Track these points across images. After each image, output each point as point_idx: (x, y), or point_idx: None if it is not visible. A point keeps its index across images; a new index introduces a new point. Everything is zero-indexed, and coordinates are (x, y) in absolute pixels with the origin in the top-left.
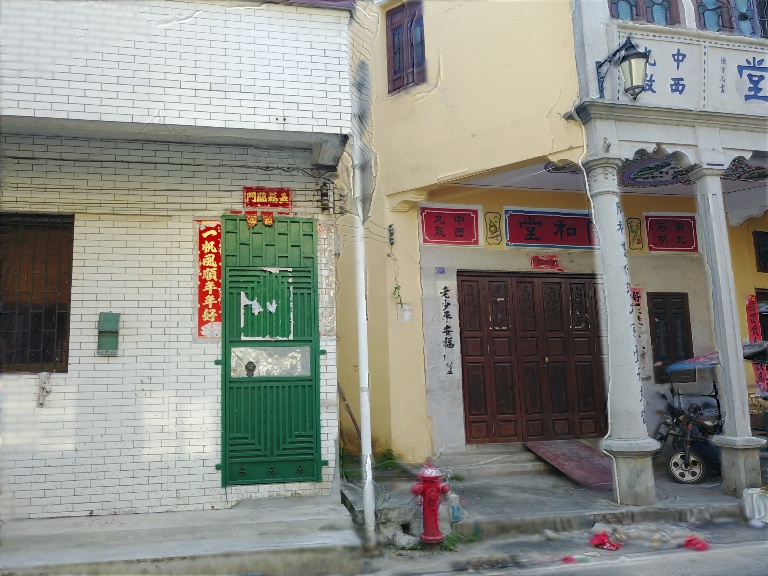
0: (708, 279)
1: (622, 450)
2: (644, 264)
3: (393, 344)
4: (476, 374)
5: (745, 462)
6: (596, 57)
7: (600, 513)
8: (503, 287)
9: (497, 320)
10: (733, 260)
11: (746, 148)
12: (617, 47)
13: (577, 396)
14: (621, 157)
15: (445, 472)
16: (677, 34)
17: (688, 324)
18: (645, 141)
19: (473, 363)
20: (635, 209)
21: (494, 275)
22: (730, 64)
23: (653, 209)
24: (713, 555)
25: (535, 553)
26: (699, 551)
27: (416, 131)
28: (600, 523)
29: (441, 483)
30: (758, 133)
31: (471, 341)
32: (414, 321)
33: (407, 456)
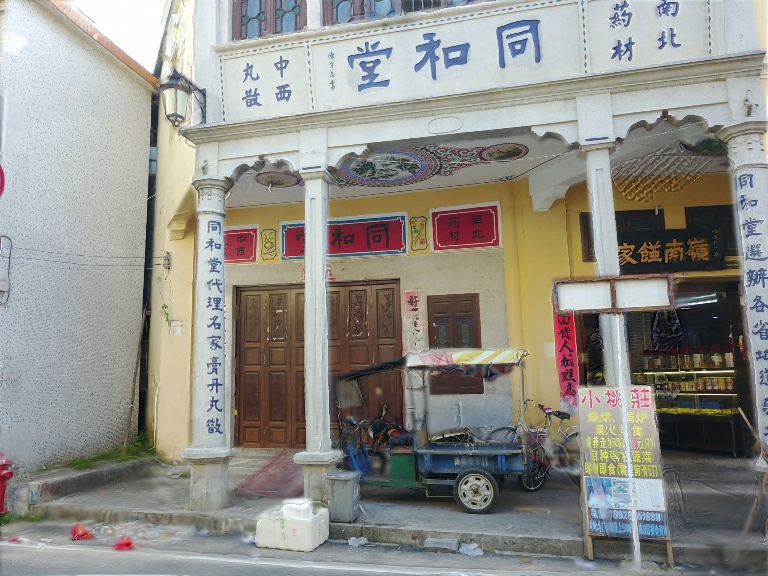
0: (506, 276)
1: (182, 456)
2: (426, 265)
3: (164, 356)
4: (252, 382)
5: (309, 479)
6: (203, 85)
7: (144, 512)
8: (284, 299)
9: (275, 331)
10: (536, 251)
11: (357, 143)
12: (219, 71)
13: (350, 406)
14: (218, 176)
15: (11, 462)
16: (277, 42)
17: (477, 328)
18: (247, 156)
19: (250, 372)
20: (420, 207)
21: (272, 288)
22: (339, 57)
23: (440, 204)
24: (110, 555)
25: (29, 534)
26: (120, 551)
27: (184, 167)
28: (138, 521)
29: (5, 471)
30: (375, 123)
31: (251, 352)
32: (184, 335)
33: (169, 454)
